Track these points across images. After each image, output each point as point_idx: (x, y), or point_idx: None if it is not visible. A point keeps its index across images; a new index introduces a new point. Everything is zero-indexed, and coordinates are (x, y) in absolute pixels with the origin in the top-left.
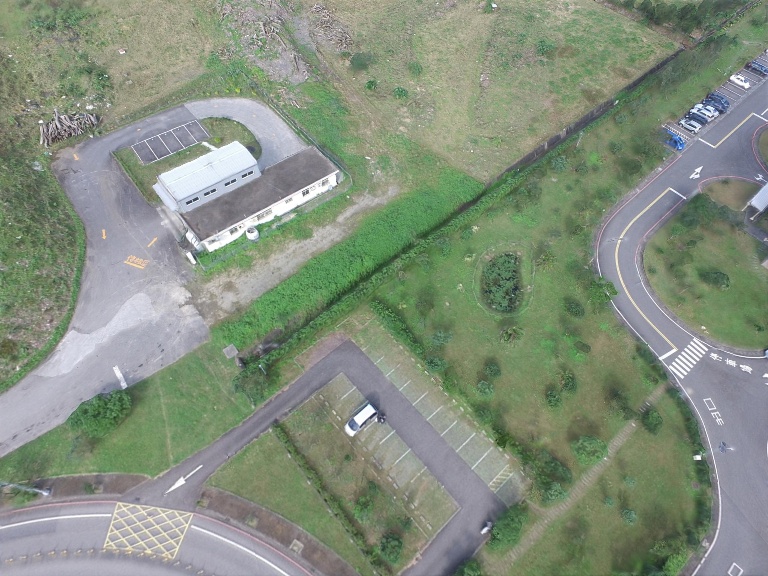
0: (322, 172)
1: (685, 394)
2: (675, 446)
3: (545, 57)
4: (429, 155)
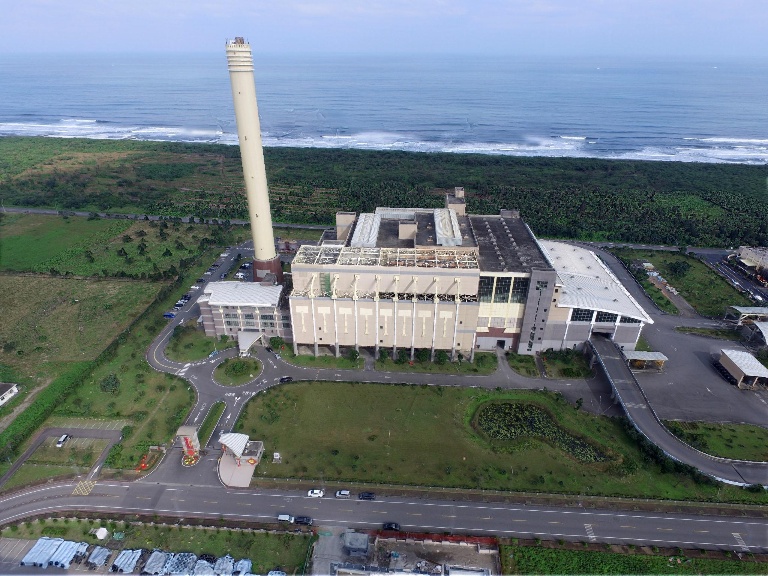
0: (8, 388)
1: (185, 378)
2: (182, 390)
3: (108, 310)
4: (62, 363)
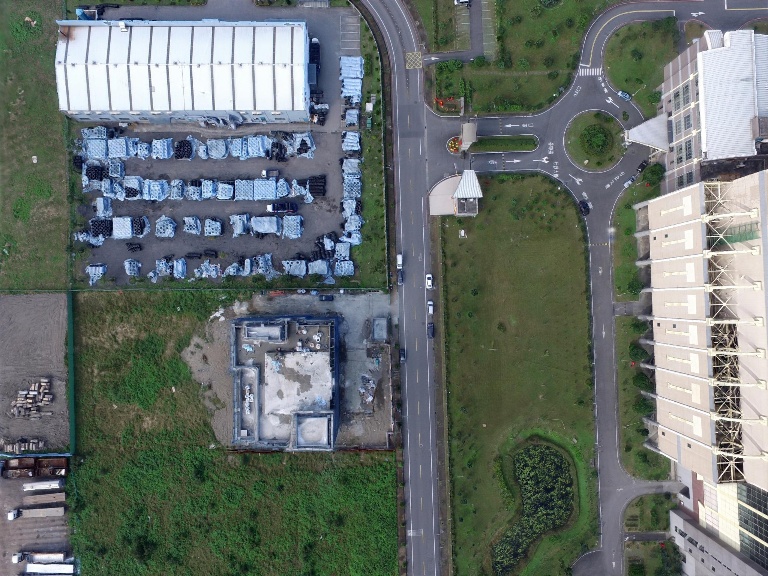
0: None
1: (574, 80)
2: (552, 88)
3: None
4: None
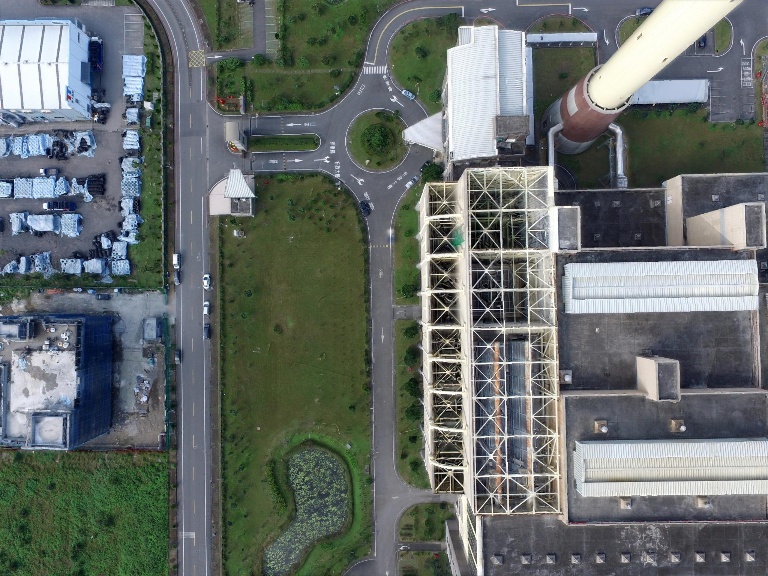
0: None
1: (358, 78)
2: None
3: None
4: None
